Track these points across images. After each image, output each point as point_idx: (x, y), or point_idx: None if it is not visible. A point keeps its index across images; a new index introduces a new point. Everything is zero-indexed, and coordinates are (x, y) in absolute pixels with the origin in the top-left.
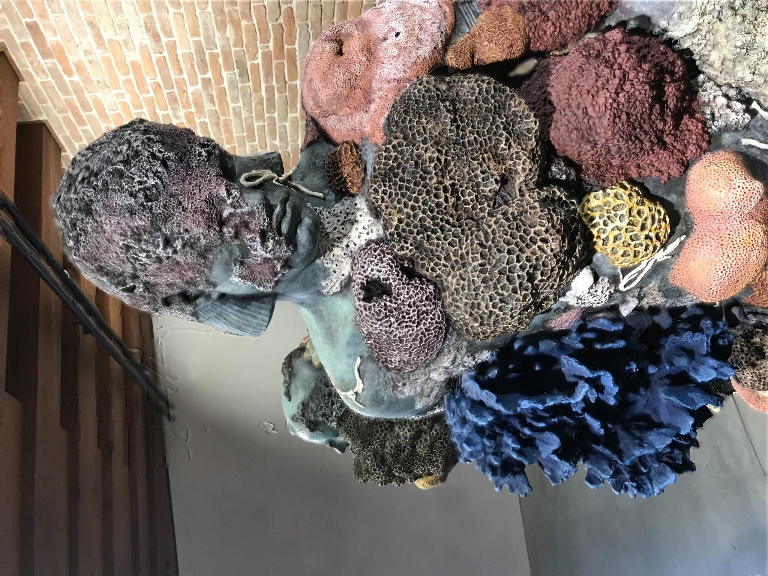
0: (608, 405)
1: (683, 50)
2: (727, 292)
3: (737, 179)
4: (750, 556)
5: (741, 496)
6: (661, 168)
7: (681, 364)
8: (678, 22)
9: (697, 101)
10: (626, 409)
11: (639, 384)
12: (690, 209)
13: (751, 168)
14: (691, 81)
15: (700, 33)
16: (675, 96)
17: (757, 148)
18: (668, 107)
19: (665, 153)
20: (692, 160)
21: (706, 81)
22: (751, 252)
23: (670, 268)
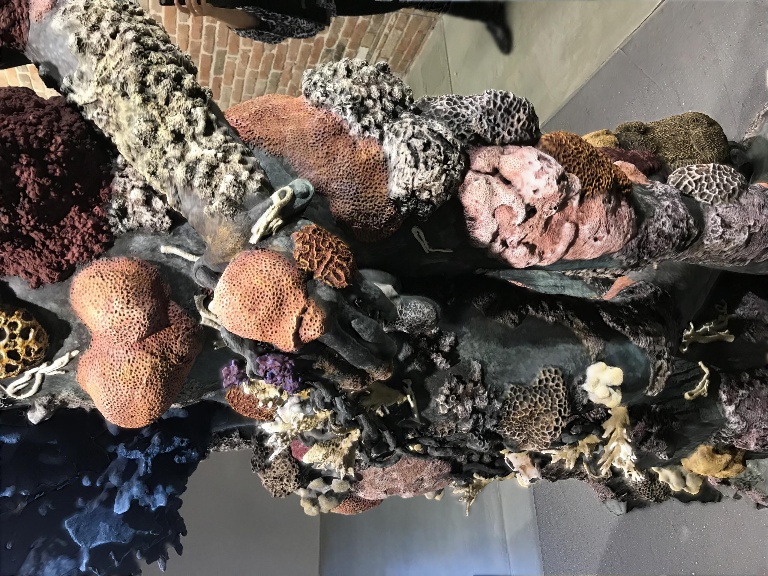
0: (35, 514)
1: (89, 120)
2: (129, 424)
3: (117, 301)
4: (475, 558)
5: (478, 502)
6: (28, 269)
7: (113, 483)
8: (80, 83)
9: (109, 188)
10: (66, 517)
11: (78, 494)
12: (83, 321)
13: (171, 283)
14: (114, 159)
15: (101, 105)
16: (37, 184)
17: (184, 259)
18: (27, 196)
19: (26, 253)
20: (80, 264)
21: (129, 164)
22: (134, 390)
23: (76, 381)
